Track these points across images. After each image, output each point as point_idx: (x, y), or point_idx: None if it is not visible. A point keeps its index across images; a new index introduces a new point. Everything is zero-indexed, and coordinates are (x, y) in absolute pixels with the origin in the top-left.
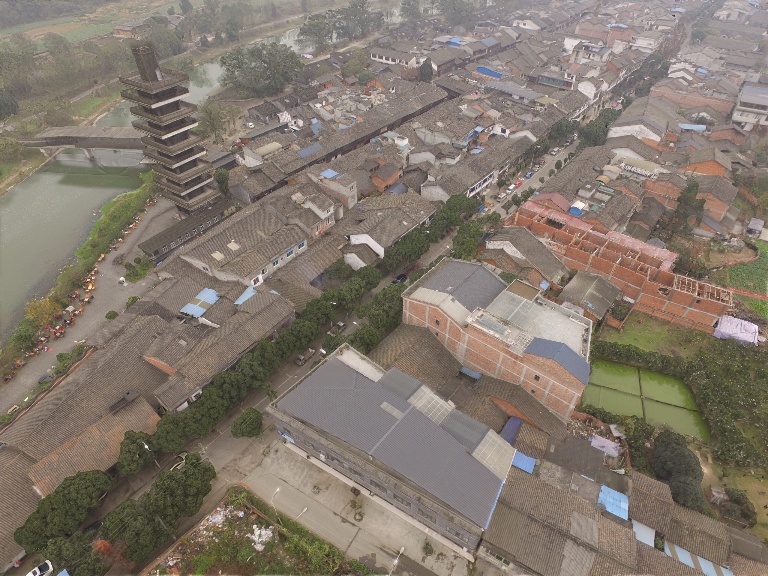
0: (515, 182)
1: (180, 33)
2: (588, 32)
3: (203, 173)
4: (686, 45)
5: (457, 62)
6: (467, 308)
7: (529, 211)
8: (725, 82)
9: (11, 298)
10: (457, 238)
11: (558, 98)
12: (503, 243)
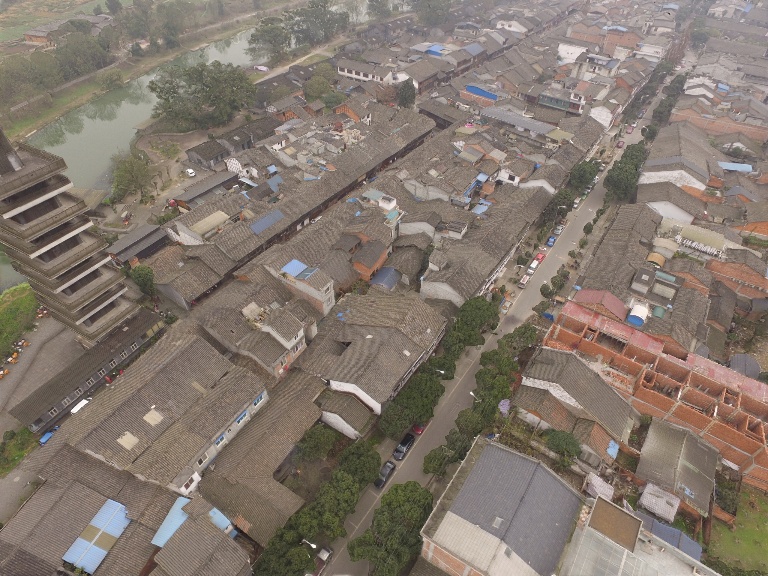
0: (537, 255)
1: (104, 41)
2: (581, 35)
3: (109, 287)
4: (687, 48)
5: (440, 76)
6: (531, 565)
7: (572, 319)
8: (756, 103)
9: None
10: (483, 378)
11: (571, 130)
12: (549, 384)
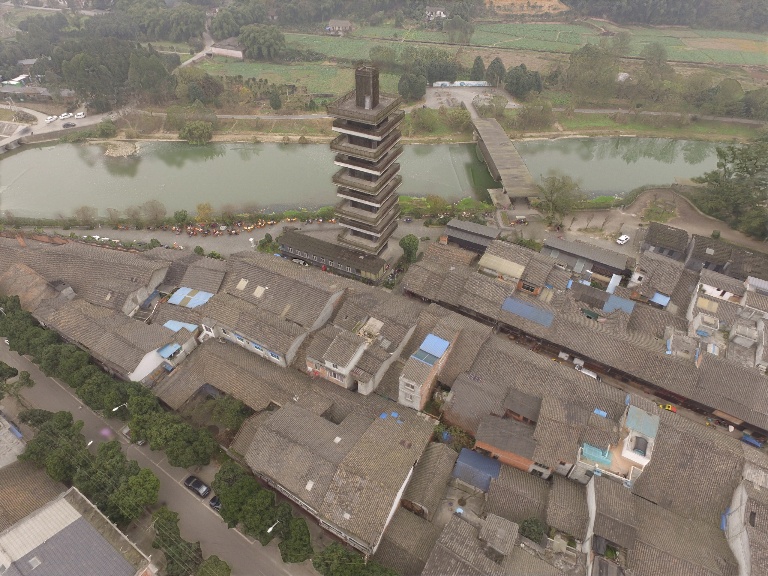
0: None
1: None
2: None
3: None
4: None
5: None
6: None
7: None
8: None
9: (266, 200)
10: None
11: None
12: None
